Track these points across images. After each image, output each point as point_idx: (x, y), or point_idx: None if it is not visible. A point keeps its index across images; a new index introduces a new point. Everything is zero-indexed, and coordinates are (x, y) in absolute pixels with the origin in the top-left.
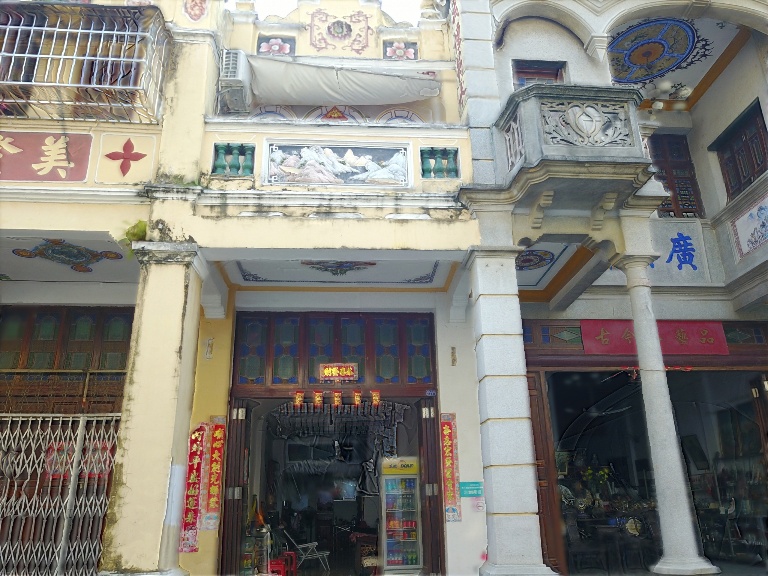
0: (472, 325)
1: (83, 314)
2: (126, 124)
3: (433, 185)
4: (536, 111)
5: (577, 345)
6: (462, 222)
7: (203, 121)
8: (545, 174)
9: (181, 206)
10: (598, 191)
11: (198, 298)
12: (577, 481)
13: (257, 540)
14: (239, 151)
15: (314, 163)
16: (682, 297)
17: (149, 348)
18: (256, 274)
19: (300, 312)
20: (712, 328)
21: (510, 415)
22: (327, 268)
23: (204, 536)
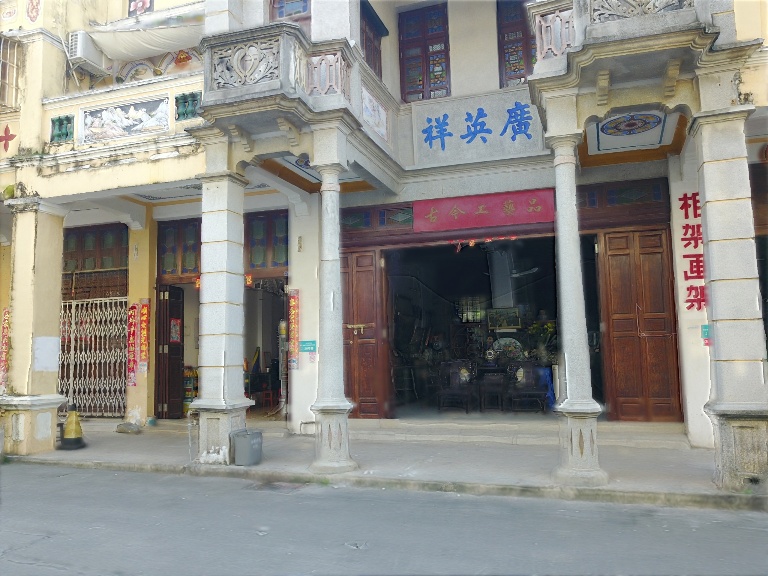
0: (315, 216)
1: (70, 233)
2: (5, 114)
3: (183, 126)
4: (207, 62)
5: (408, 225)
6: (194, 156)
7: (41, 104)
8: (212, 116)
9: (31, 171)
10: (268, 119)
11: (58, 230)
12: (526, 334)
13: (196, 379)
14: (67, 121)
15: (109, 122)
16: (511, 169)
17: (19, 268)
18: (150, 195)
19: (196, 218)
20: (541, 196)
21: (213, 300)
22: (187, 186)
23: (139, 376)
